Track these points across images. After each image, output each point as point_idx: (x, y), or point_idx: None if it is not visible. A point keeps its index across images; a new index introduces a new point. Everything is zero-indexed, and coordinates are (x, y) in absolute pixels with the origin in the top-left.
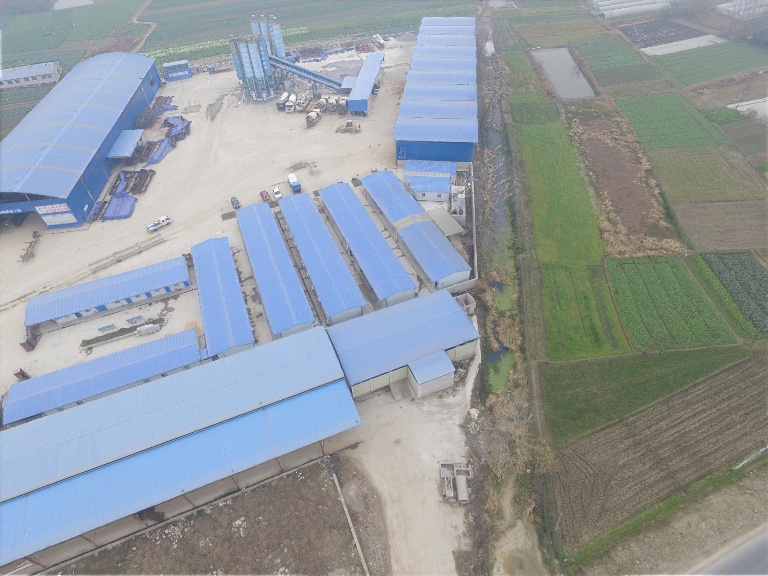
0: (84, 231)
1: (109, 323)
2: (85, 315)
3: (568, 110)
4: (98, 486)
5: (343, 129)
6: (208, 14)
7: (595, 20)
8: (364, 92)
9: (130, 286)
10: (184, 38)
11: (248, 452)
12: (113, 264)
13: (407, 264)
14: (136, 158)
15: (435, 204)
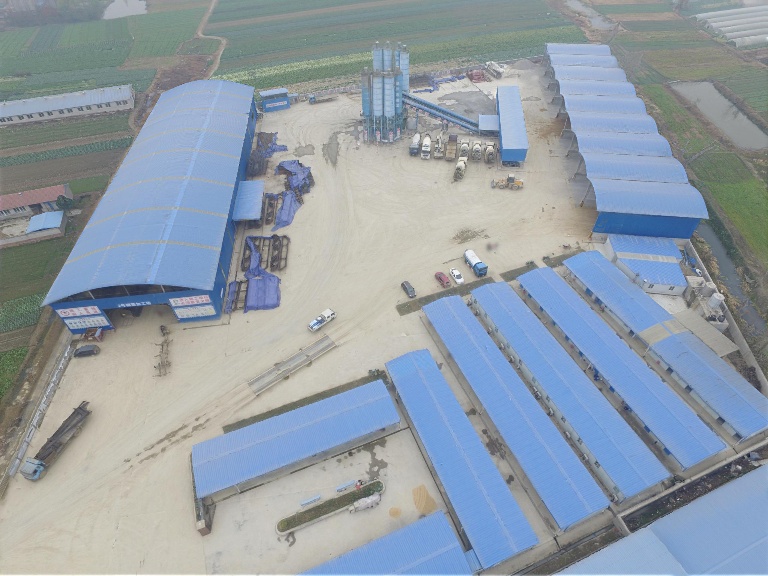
0: (225, 326)
1: (304, 486)
2: None
3: (757, 164)
4: None
5: (503, 185)
6: (282, 29)
7: (724, 49)
8: (520, 138)
9: (326, 430)
10: (265, 58)
11: None
12: (279, 382)
13: None
14: (260, 218)
15: (667, 299)
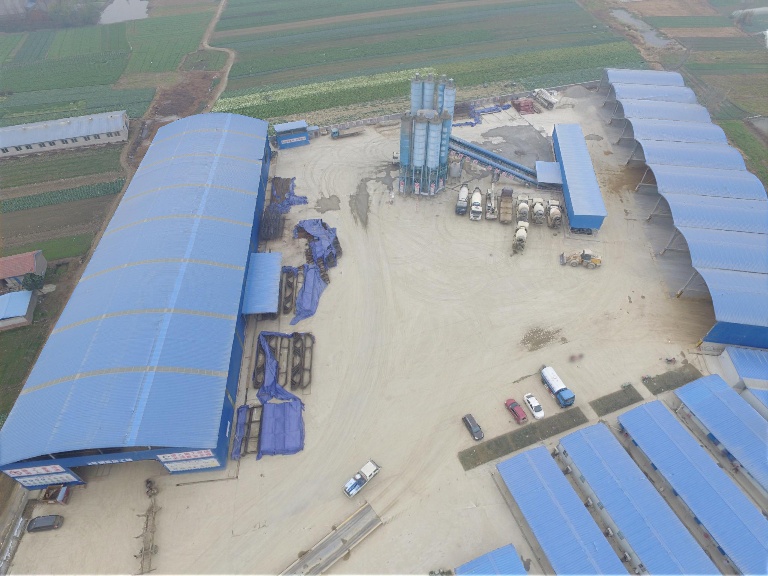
0: (232, 483)
1: None
2: None
3: None
4: None
5: (576, 262)
6: (297, 41)
7: None
8: (593, 200)
9: None
10: (279, 77)
11: None
12: None
13: None
14: None
15: None
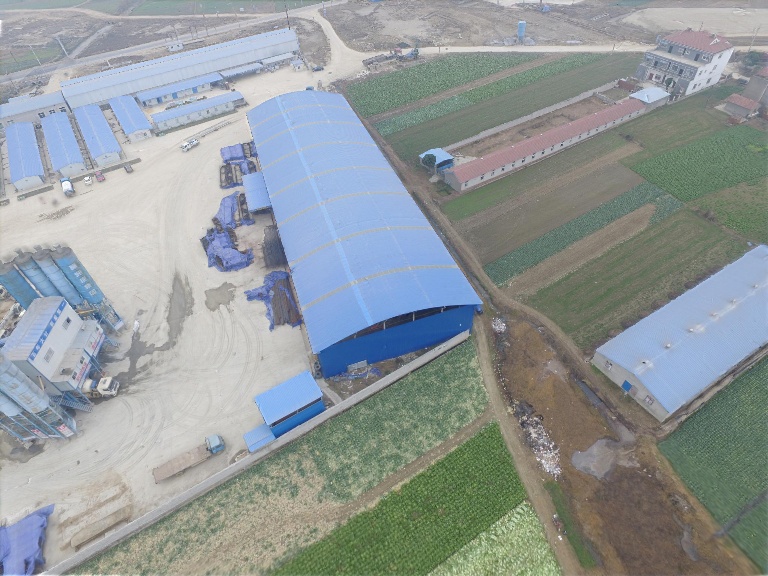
0: None
1: None
2: None
3: None
4: None
5: None
6: None
7: None
8: None
9: None
10: None
11: (106, 72)
12: None
13: (4, 150)
14: None
15: None
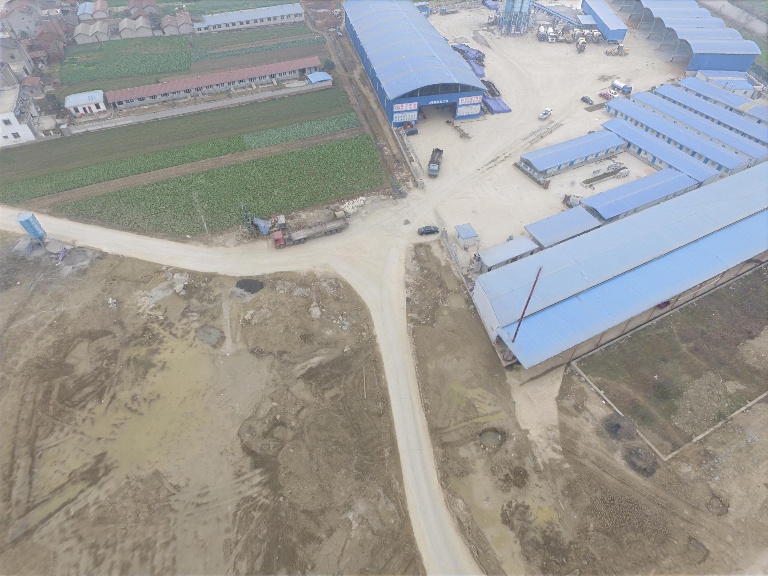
0: (485, 120)
1: (584, 172)
2: (561, 168)
3: None
4: (735, 236)
5: (615, 52)
6: None
7: None
8: (619, 24)
9: (589, 146)
10: None
11: None
12: (539, 139)
13: None
14: None
15: None
